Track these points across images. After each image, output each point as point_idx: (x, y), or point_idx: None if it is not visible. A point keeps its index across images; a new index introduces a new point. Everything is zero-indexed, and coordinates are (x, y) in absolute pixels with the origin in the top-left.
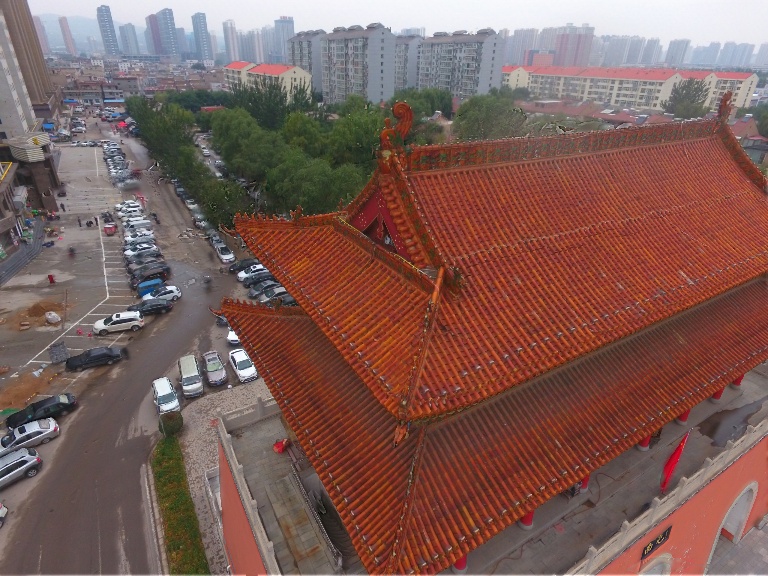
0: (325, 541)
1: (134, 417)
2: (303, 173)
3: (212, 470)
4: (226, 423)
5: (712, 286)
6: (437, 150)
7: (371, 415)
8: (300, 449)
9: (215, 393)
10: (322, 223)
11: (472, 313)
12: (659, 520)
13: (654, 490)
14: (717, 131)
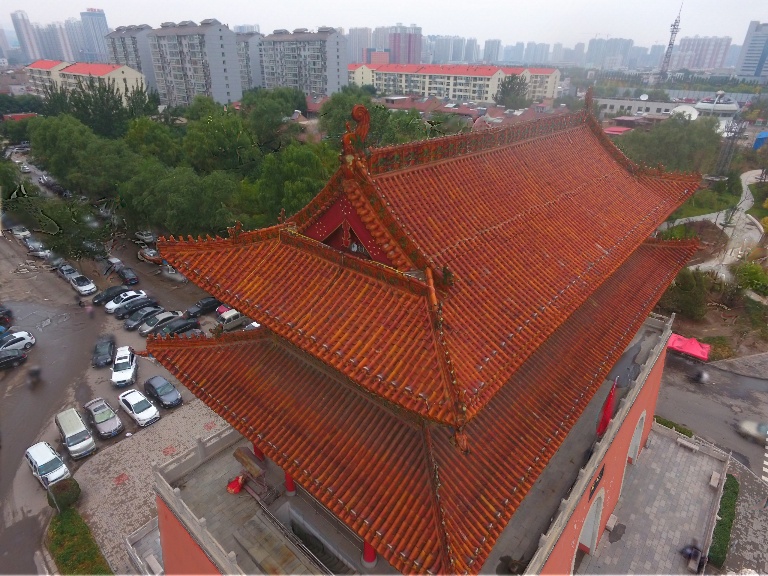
0: (319, 571)
1: (8, 499)
2: (166, 184)
3: (134, 534)
4: (164, 476)
5: (621, 253)
6: (392, 151)
7: (363, 429)
8: (264, 483)
9: (111, 446)
10: (267, 237)
11: (462, 308)
12: (599, 461)
13: (588, 436)
14: (586, 120)
